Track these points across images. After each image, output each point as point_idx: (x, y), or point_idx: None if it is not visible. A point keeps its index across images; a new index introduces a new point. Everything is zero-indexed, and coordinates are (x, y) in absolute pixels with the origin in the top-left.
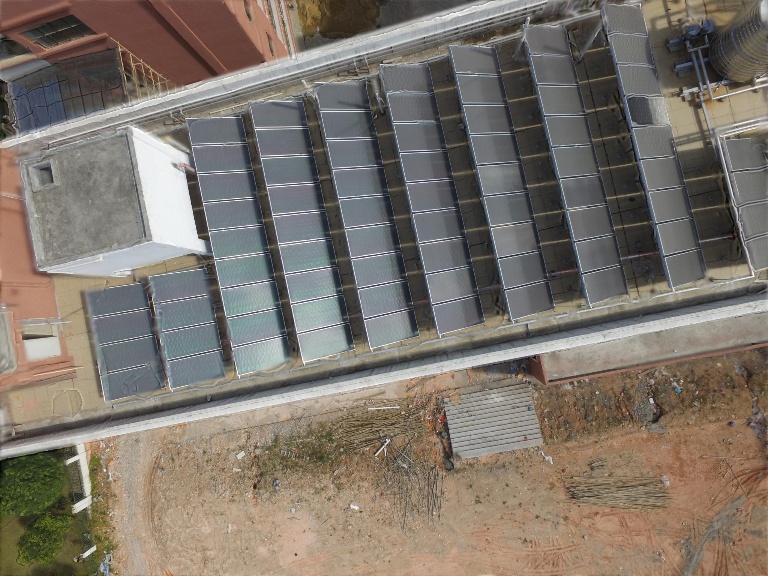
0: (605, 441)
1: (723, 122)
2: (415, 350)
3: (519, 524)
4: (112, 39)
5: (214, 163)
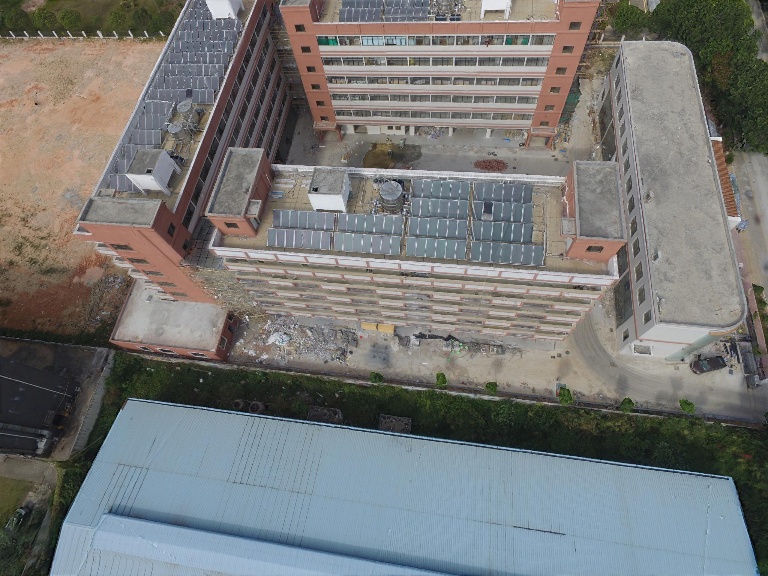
0: None
1: None
2: (169, 48)
3: None
4: None
5: None
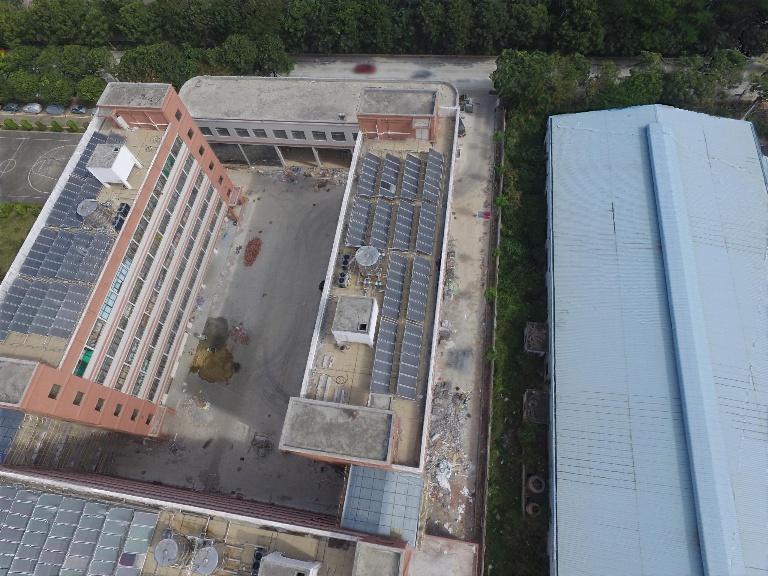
0: None
1: (163, 574)
2: None
3: None
4: (23, 412)
5: None
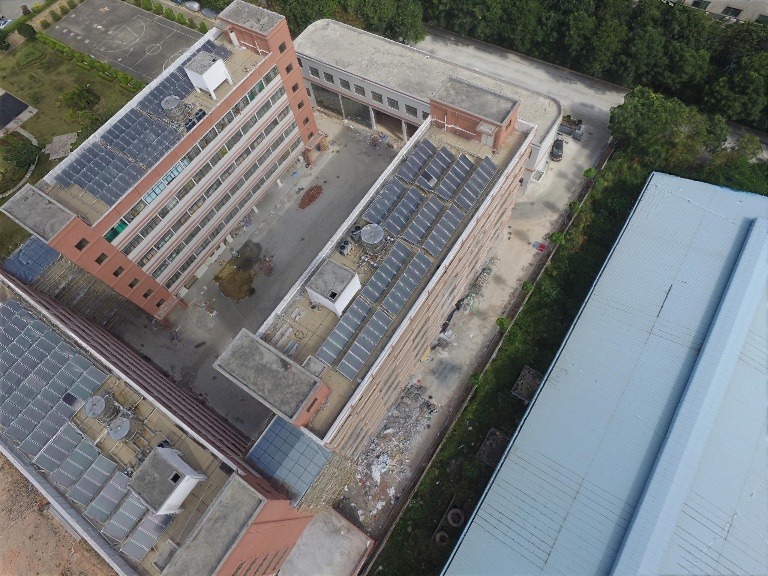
0: (97, 569)
1: None
2: None
3: (29, 568)
4: None
5: (5, 313)
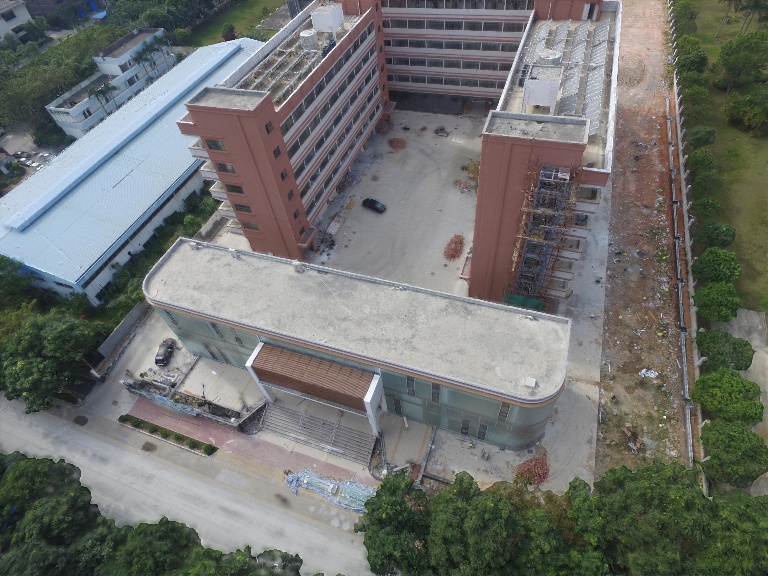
0: None
1: None
2: None
3: None
4: None
5: None
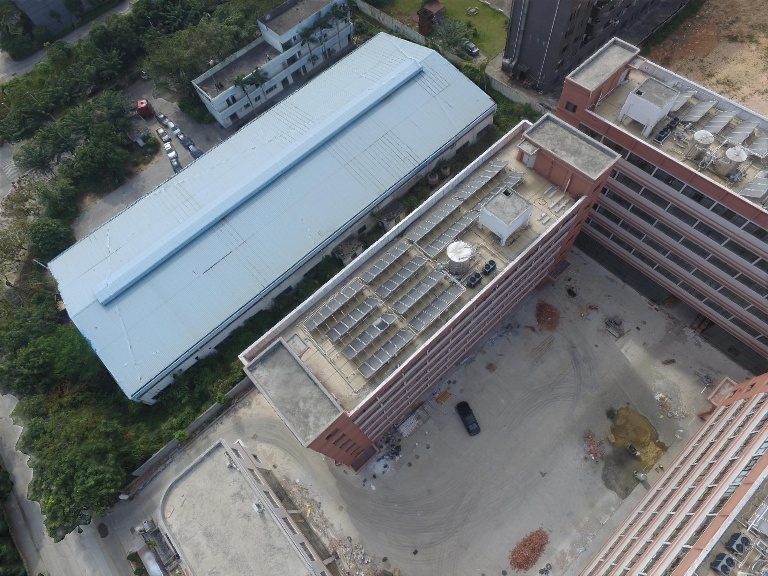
0: None
1: (742, 164)
2: None
3: None
4: None
5: None
